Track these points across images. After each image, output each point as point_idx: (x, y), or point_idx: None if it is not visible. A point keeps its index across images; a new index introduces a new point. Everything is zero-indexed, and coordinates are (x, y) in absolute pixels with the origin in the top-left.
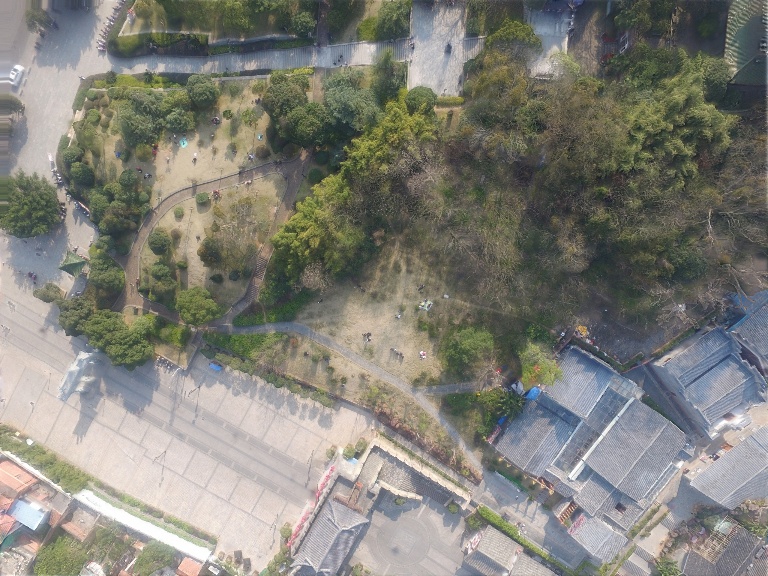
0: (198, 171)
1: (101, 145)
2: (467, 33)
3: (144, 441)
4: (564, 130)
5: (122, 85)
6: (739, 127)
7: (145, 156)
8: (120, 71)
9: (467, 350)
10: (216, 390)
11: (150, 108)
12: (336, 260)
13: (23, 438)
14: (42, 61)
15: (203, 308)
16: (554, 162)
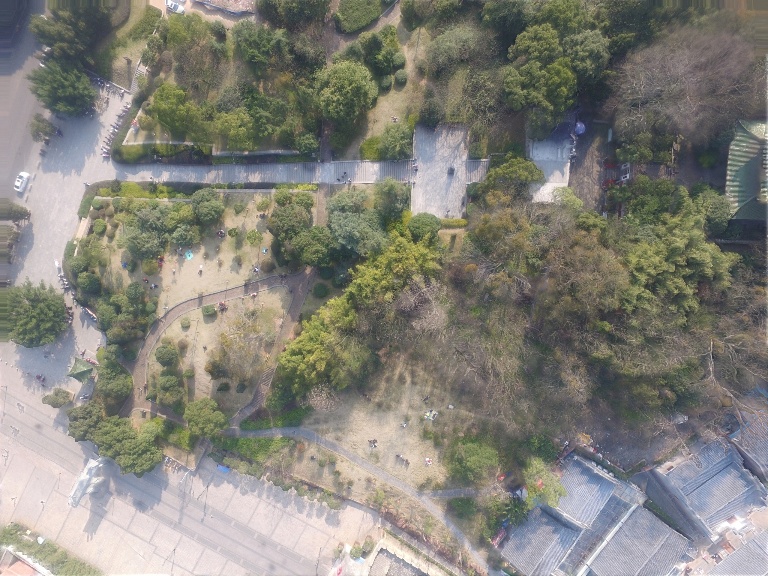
0: (204, 282)
1: (107, 255)
2: (470, 156)
3: (154, 539)
4: (567, 264)
5: (127, 195)
6: (740, 266)
7: (151, 271)
8: (125, 177)
9: (472, 468)
10: (224, 489)
11: (156, 224)
12: (342, 377)
13: (34, 536)
14: (47, 167)
15: (211, 422)
16: (558, 304)
